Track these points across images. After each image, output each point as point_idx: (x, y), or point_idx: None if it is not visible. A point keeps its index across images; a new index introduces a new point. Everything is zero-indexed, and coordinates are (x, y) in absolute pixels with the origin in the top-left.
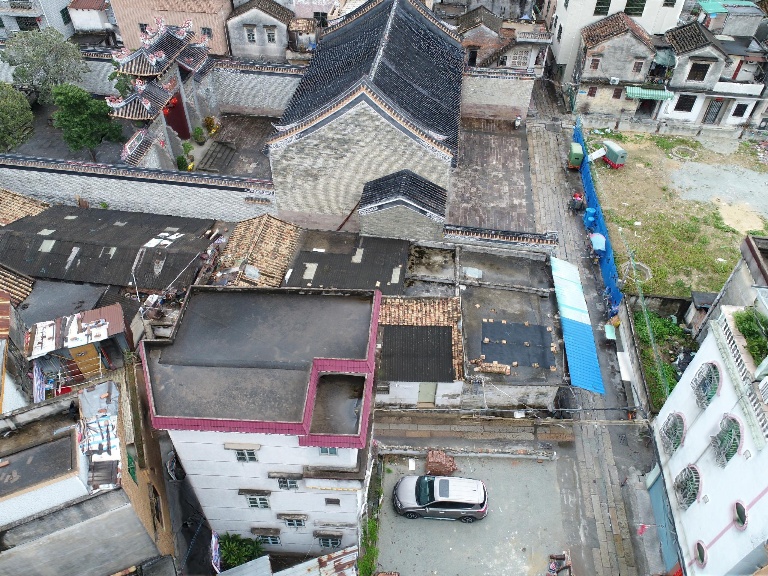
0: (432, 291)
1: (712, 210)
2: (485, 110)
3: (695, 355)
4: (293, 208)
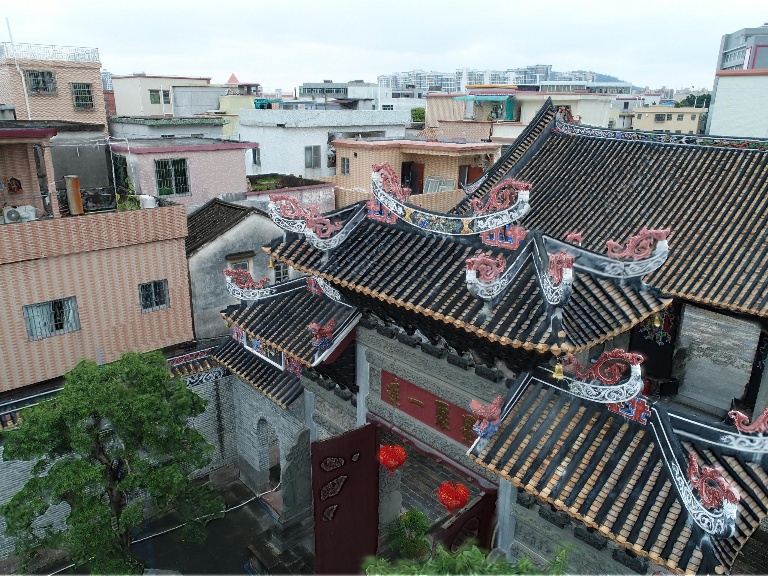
0: None
1: None
2: None
3: None
4: None
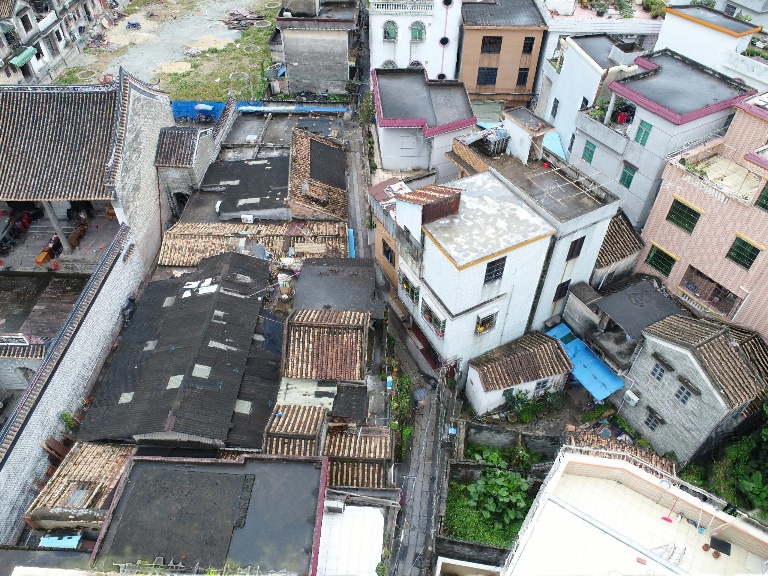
0: None
1: (165, 75)
2: None
3: (371, 34)
4: (141, 235)
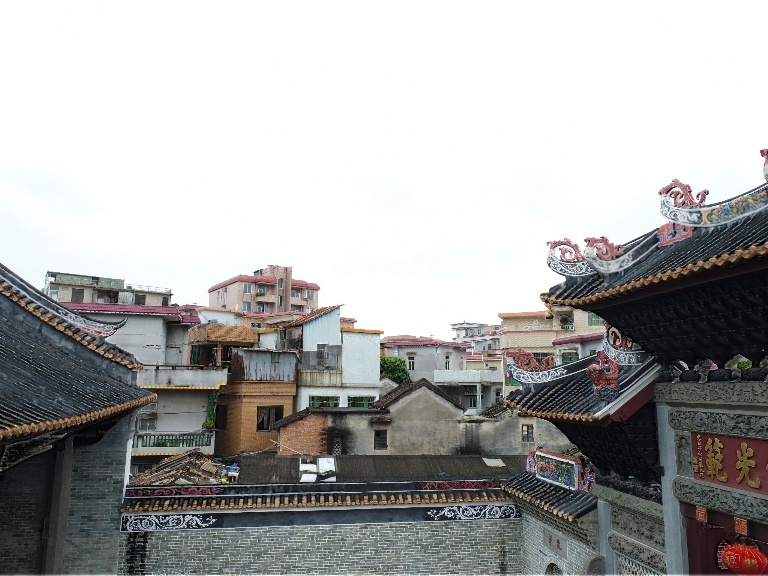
0: None
1: None
2: None
3: None
4: None
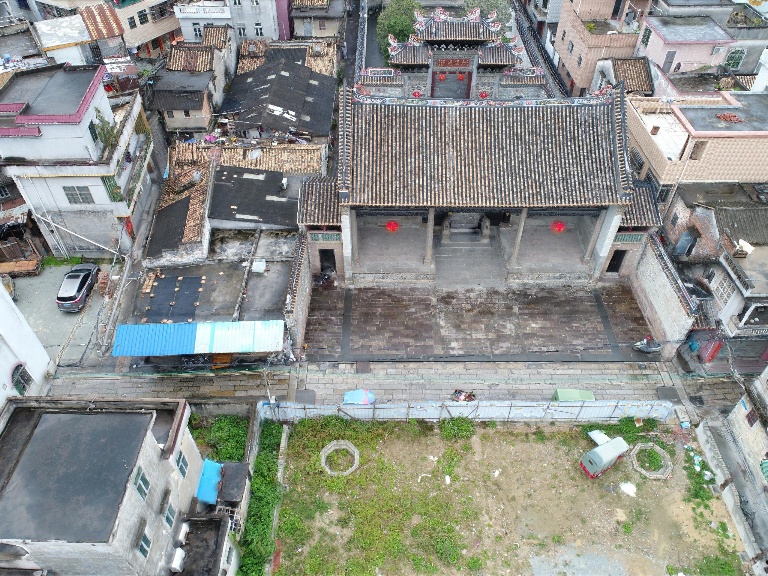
0: (241, 246)
1: None
2: (648, 306)
3: None
4: None
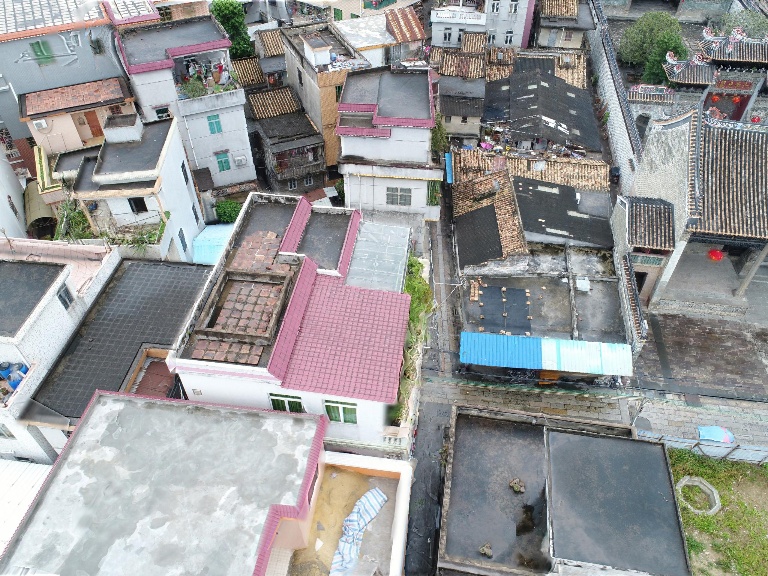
0: (554, 261)
1: None
2: None
3: None
4: (636, 187)
